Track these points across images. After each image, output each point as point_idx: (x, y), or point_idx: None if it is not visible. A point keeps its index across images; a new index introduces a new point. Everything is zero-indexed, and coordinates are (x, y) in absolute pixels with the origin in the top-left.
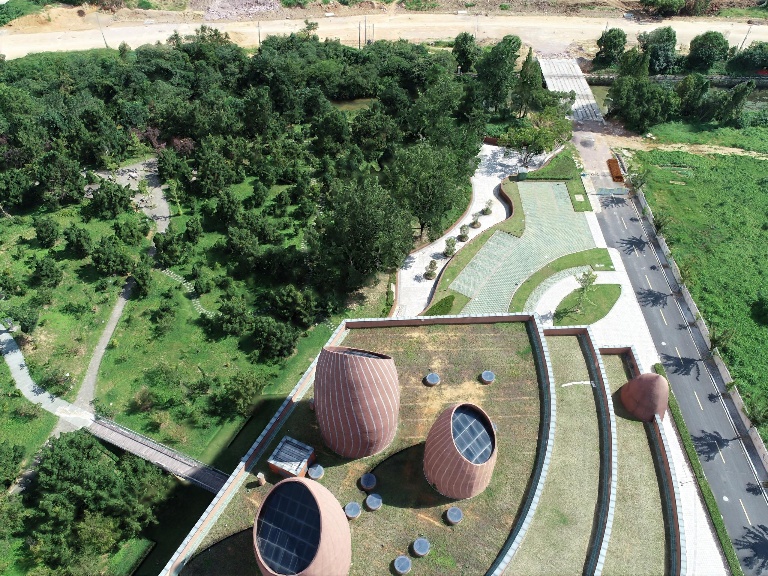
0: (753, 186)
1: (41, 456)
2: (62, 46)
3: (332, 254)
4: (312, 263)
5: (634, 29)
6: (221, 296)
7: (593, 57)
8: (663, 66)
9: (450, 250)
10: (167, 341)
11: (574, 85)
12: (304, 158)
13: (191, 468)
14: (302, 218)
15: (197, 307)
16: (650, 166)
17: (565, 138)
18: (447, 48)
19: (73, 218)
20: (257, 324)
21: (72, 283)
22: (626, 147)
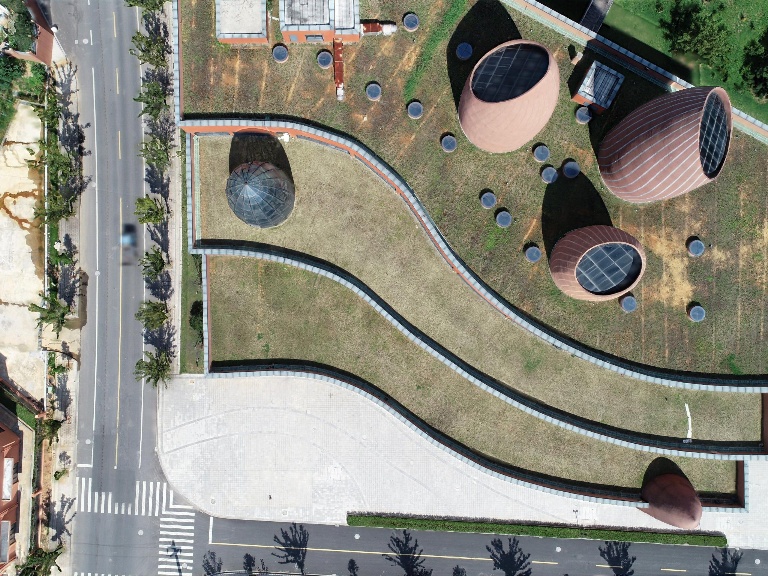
0: None
1: None
2: None
3: None
4: None
5: None
6: None
7: None
8: None
9: None
10: None
11: None
12: None
13: None
14: None
15: None
16: None
17: None
18: None
19: None
20: None
21: None
22: None
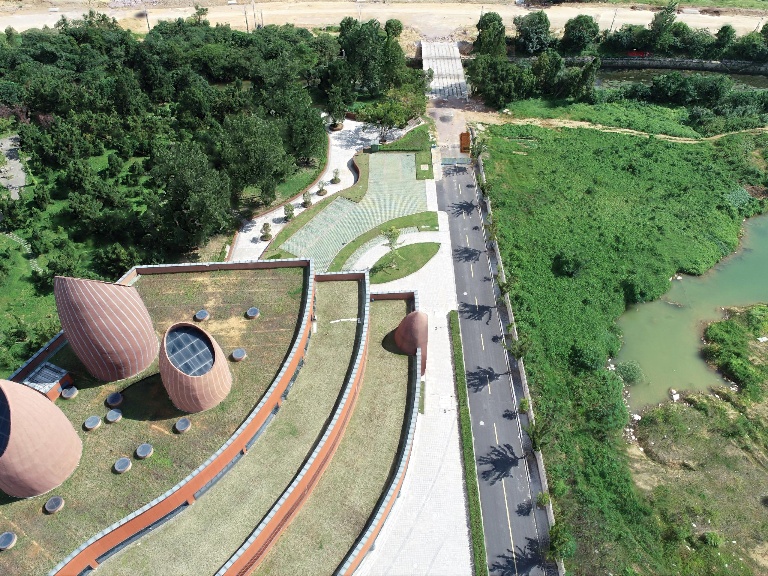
0: (589, 155)
1: None
2: None
3: None
4: (155, 227)
5: (521, 14)
6: (59, 256)
7: None
8: (537, 48)
9: (288, 214)
10: None
11: (448, 66)
12: (164, 132)
13: None
14: (152, 186)
15: (33, 266)
16: (498, 138)
17: (418, 113)
18: (338, 33)
19: None
20: None
21: None
22: (482, 122)
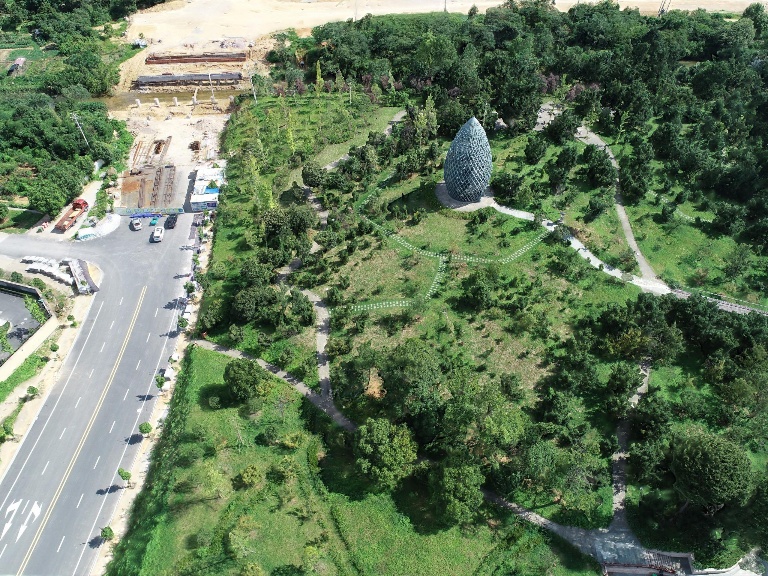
0: None
1: (666, 308)
2: (376, 12)
3: None
4: None
5: None
6: (694, 206)
7: None
8: None
9: None
10: (680, 237)
11: None
12: None
13: None
14: (718, 150)
15: (681, 214)
16: None
17: None
18: (725, 19)
19: None
20: (762, 223)
21: None
22: None
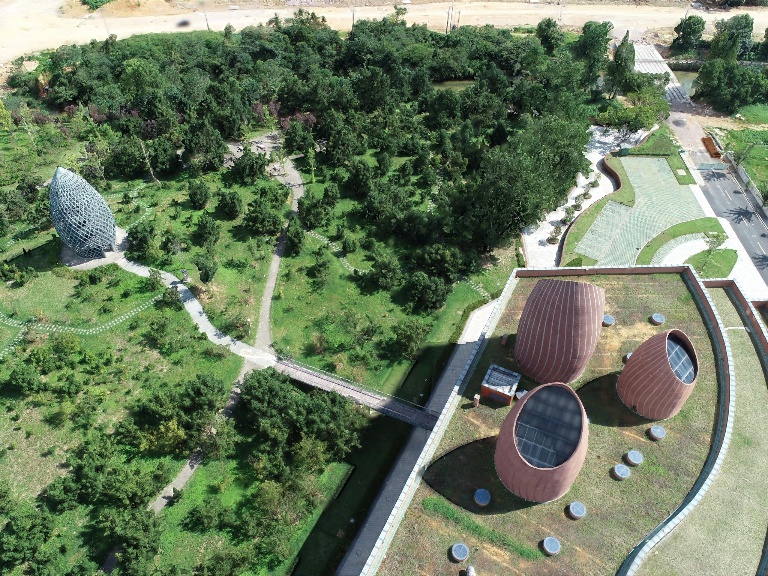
0: None
1: (242, 389)
2: (156, 29)
3: (458, 220)
4: None
5: (704, 18)
6: (365, 255)
7: (669, 44)
8: (740, 52)
9: (570, 217)
10: (326, 294)
11: (657, 69)
12: (420, 132)
13: (380, 401)
14: (426, 187)
15: (346, 265)
16: (744, 144)
17: (663, 116)
18: (526, 34)
19: (215, 184)
20: (412, 278)
21: (228, 241)
22: (717, 126)
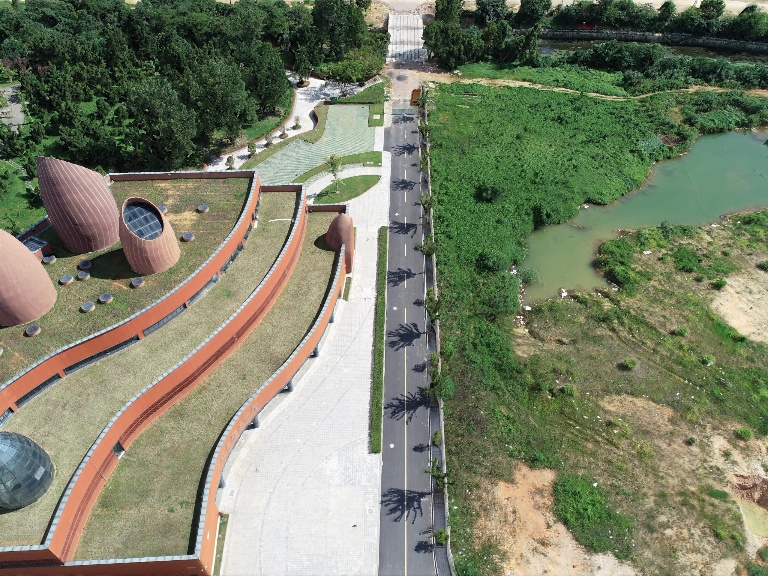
0: (524, 109)
1: None
2: None
3: None
4: None
5: None
6: None
7: None
8: (493, 20)
9: (251, 151)
10: None
11: (411, 34)
12: None
13: None
14: (134, 127)
15: (28, 186)
16: (446, 94)
17: (375, 70)
18: None
19: None
20: None
21: None
22: (433, 81)
